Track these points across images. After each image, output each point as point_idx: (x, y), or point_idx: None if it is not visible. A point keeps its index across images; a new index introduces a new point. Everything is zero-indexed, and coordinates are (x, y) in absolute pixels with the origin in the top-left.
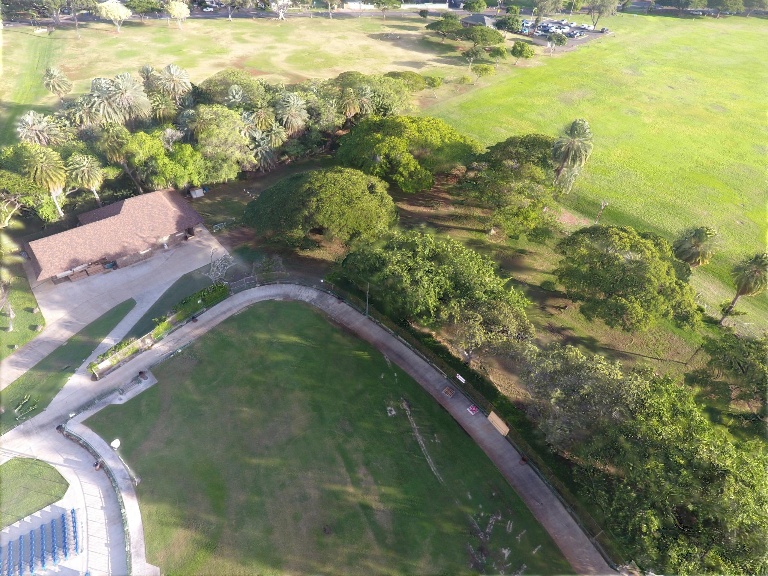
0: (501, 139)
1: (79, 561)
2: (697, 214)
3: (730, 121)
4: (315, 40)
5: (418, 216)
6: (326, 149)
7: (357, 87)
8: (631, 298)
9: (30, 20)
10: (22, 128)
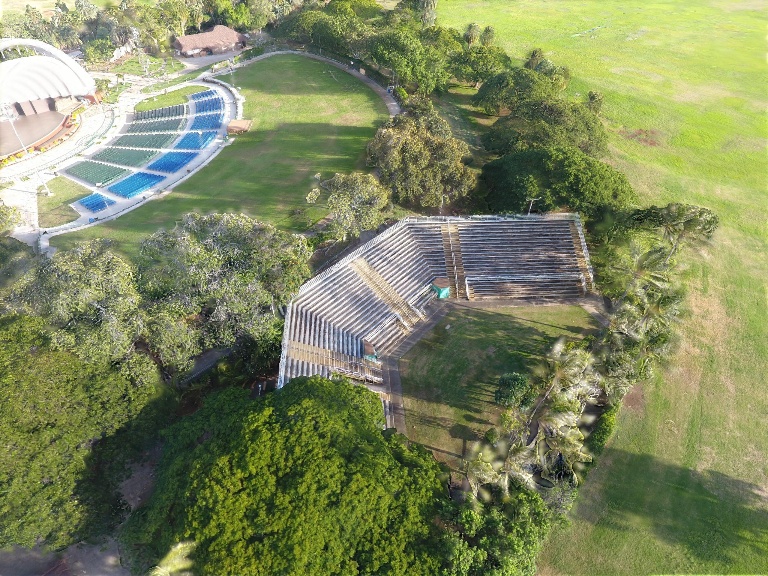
0: None
1: None
2: (505, 44)
3: (566, 14)
4: None
5: None
6: None
7: None
8: (431, 46)
9: None
10: (160, 2)
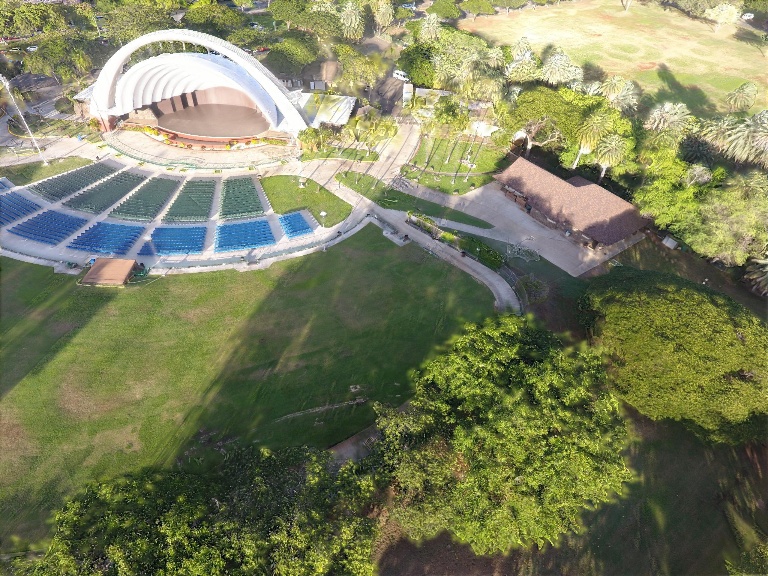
0: None
1: (284, 240)
2: None
3: None
4: None
5: None
6: None
7: None
8: None
9: None
10: (659, 110)
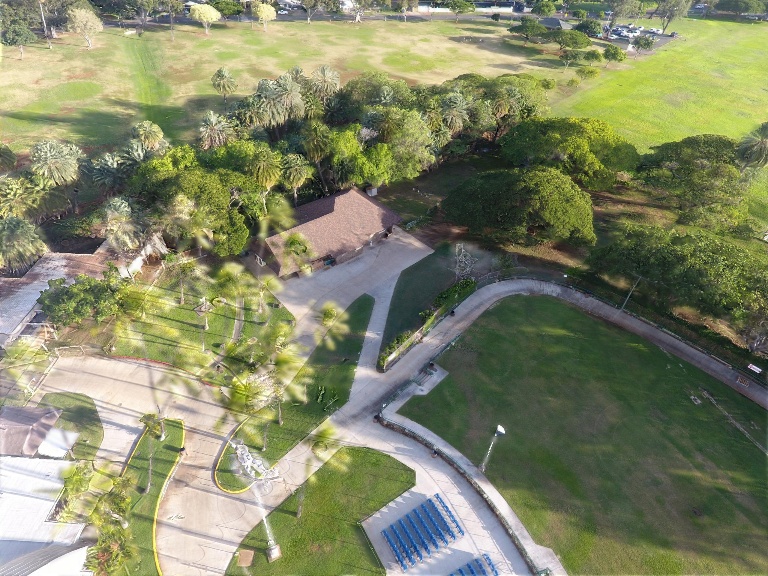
0: (632, 140)
1: (466, 543)
2: None
3: None
4: (401, 43)
5: (593, 214)
6: (471, 149)
7: (499, 89)
8: None
9: (118, 22)
10: (205, 128)
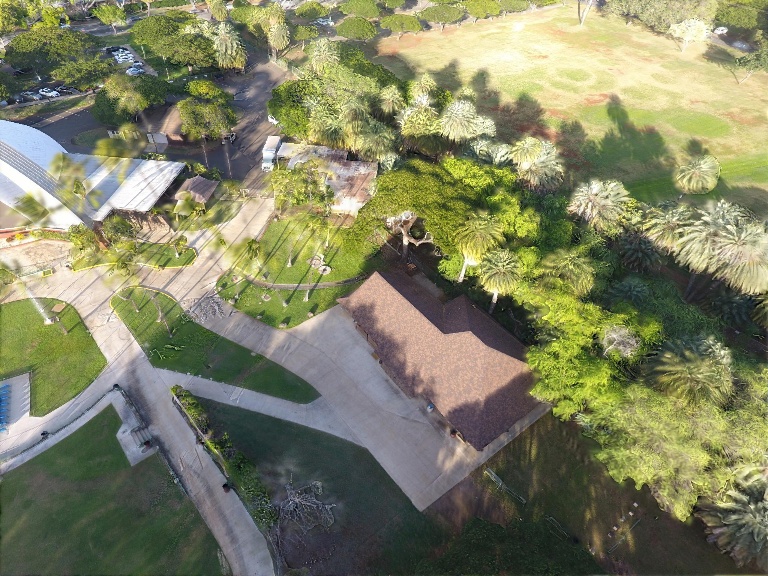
0: None
1: None
2: None
3: None
4: None
5: None
6: None
7: None
8: None
9: None
10: (586, 190)
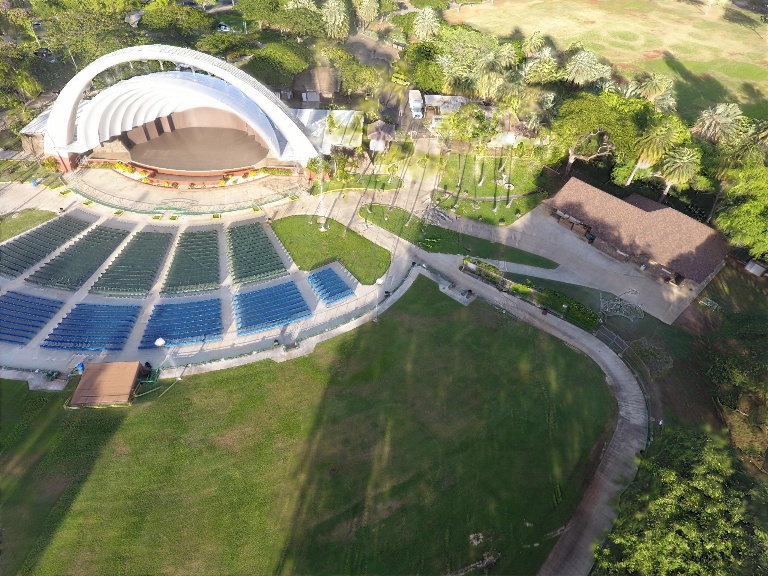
0: None
1: (321, 308)
2: None
3: None
4: None
5: None
6: None
7: None
8: None
9: None
10: (708, 112)
